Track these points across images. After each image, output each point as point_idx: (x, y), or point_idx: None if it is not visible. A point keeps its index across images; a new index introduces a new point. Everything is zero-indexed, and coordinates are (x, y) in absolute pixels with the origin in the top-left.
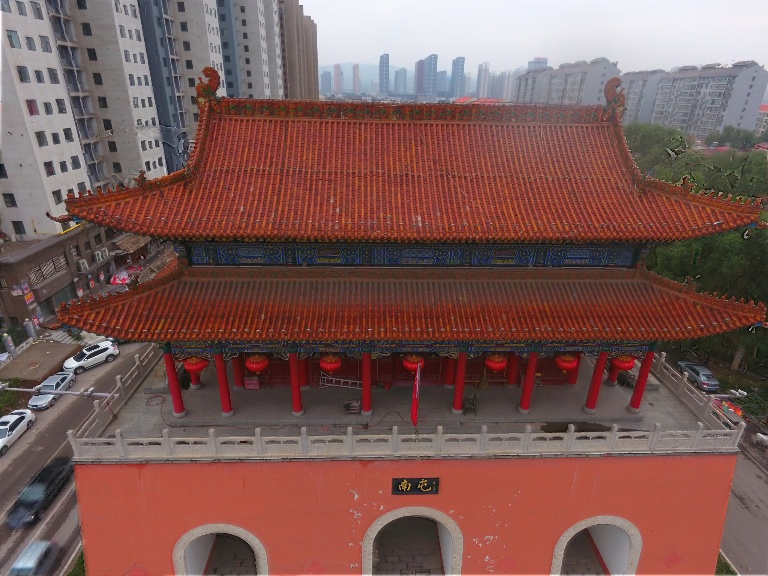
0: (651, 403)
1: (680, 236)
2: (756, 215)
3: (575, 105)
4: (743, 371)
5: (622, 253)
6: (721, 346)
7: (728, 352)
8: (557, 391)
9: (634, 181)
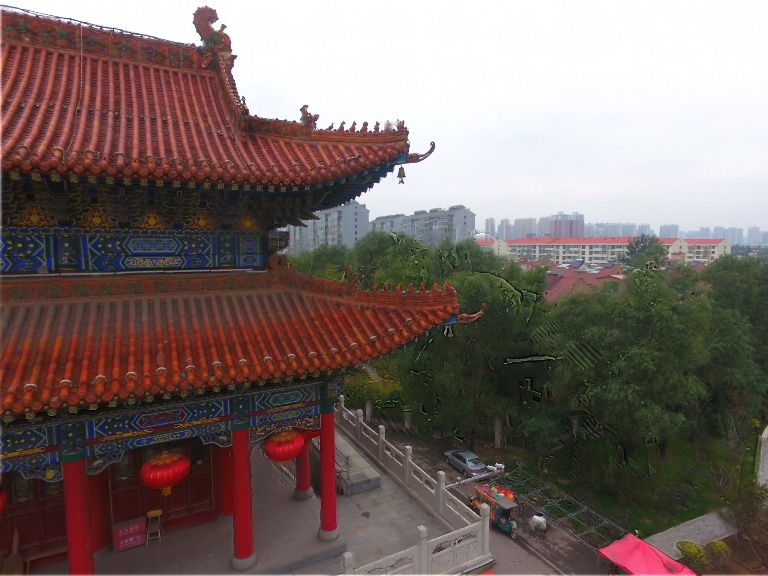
0: (366, 512)
1: (297, 178)
2: (402, 142)
3: (147, 36)
4: (504, 446)
5: (241, 244)
6: (481, 424)
7: (488, 429)
8: (194, 538)
9: (235, 124)
